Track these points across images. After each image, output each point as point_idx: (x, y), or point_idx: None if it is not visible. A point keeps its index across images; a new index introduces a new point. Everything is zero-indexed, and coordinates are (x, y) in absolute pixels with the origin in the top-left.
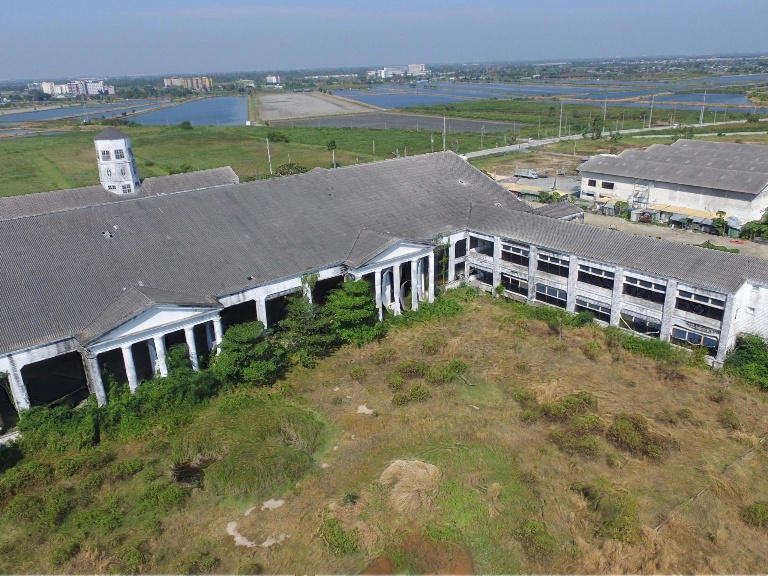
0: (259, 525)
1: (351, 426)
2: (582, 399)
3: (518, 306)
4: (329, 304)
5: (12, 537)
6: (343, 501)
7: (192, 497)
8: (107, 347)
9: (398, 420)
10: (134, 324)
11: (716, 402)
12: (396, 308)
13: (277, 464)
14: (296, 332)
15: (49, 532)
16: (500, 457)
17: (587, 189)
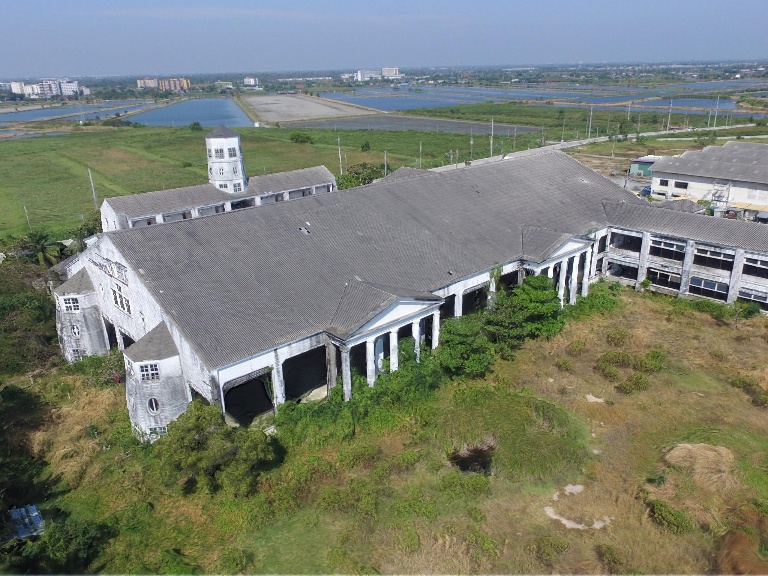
0: (577, 509)
1: (595, 414)
2: None
3: (669, 299)
4: (516, 298)
5: (340, 528)
6: (656, 483)
7: (492, 484)
8: (358, 341)
9: (635, 408)
10: (379, 318)
11: None
12: (560, 302)
13: (563, 451)
14: (497, 325)
15: (372, 522)
16: (762, 439)
17: (658, 189)
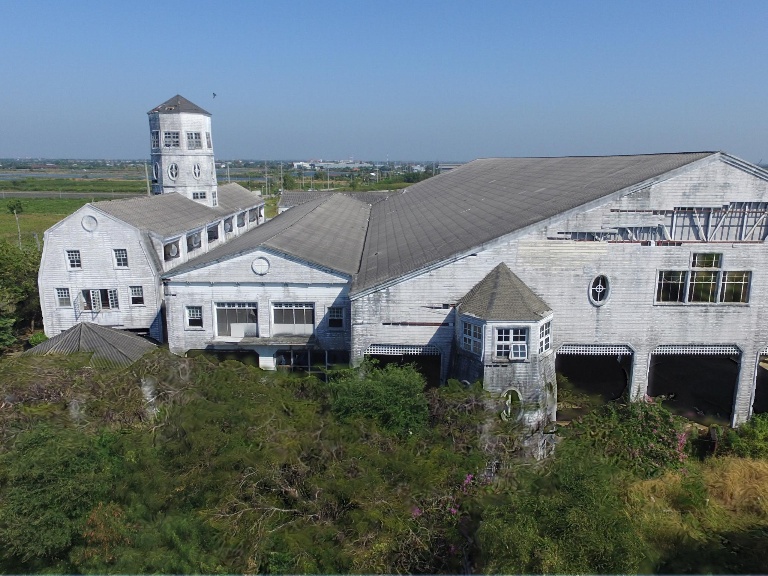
0: None
1: None
2: None
3: None
4: None
5: None
6: None
7: None
8: None
9: None
10: None
11: None
12: None
13: None
14: None
15: None
16: None
17: None
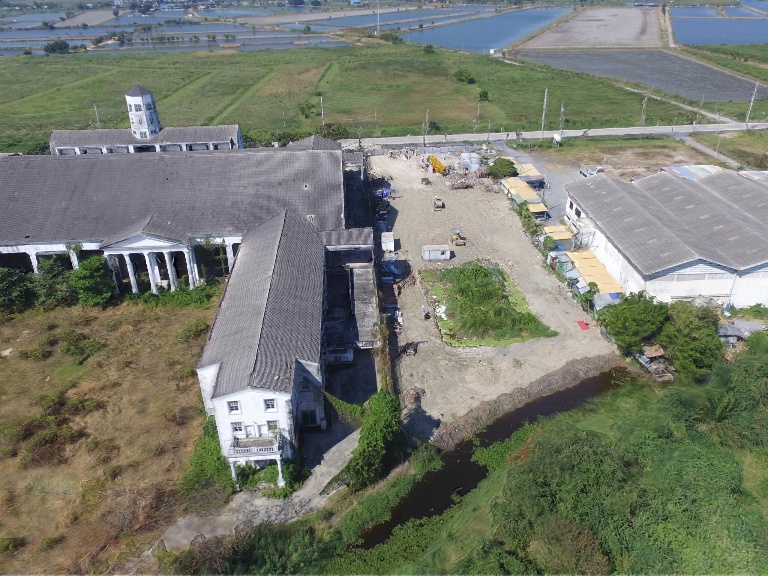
0: None
1: None
2: (82, 404)
3: None
4: None
5: None
6: None
7: None
8: None
9: (2, 367)
10: None
11: (154, 453)
12: (151, 286)
13: None
14: None
15: None
16: None
17: (568, 211)
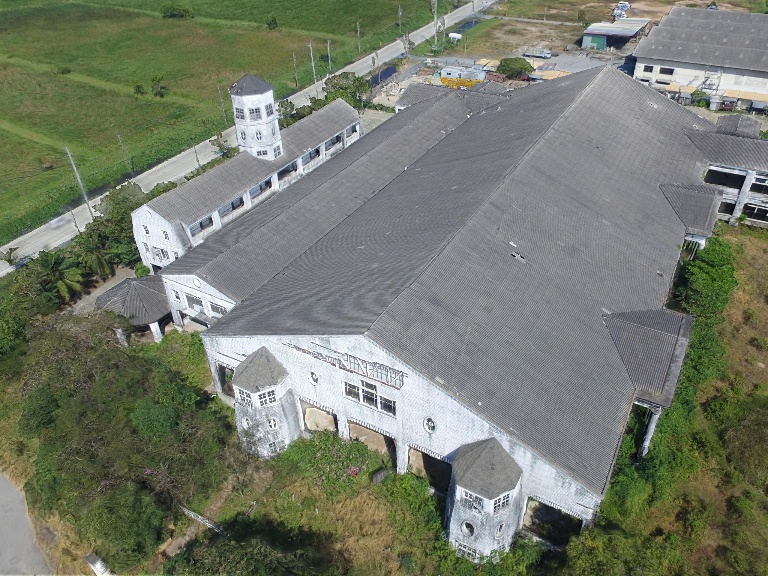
0: None
1: None
2: None
3: (767, 233)
4: (695, 278)
5: None
6: None
7: None
8: None
9: None
10: None
11: None
12: None
13: None
14: (699, 317)
15: None
16: None
17: (642, 75)
